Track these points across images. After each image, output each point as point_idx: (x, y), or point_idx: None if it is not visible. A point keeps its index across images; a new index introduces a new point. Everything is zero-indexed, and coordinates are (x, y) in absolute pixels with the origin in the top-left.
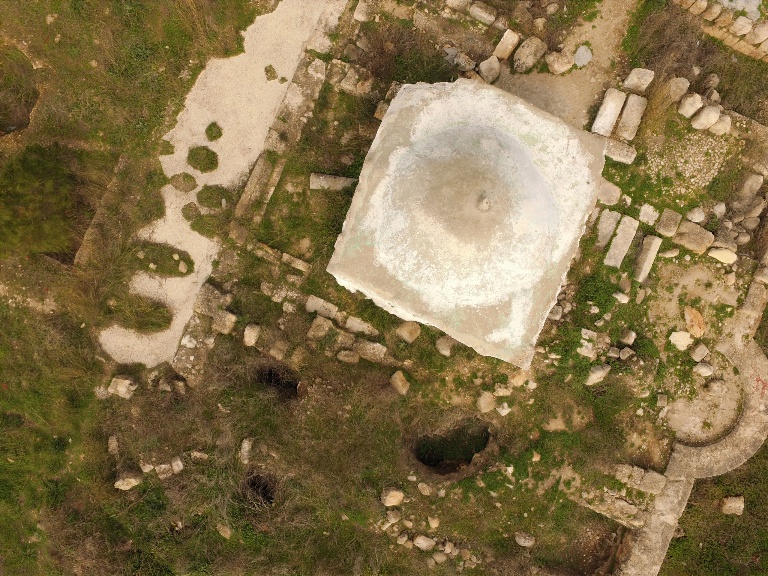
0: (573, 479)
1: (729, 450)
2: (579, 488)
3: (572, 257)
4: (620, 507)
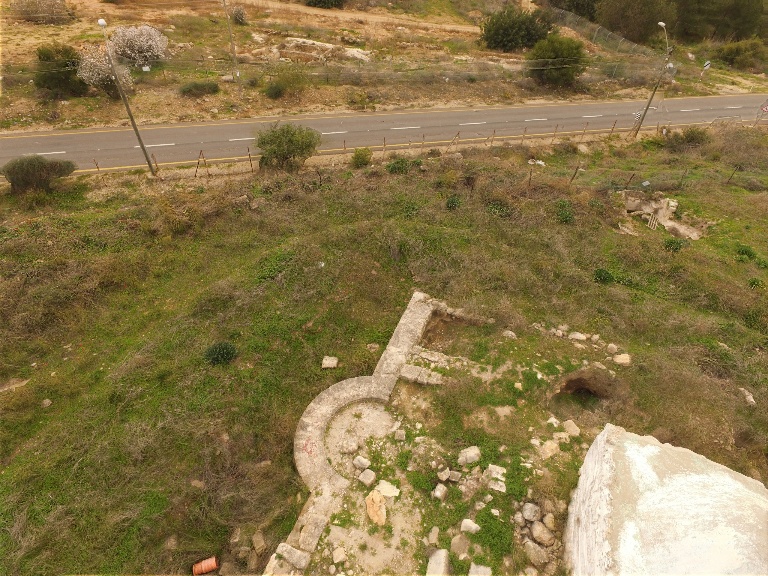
0: (479, 373)
1: (343, 396)
2: (471, 368)
3: (609, 529)
4: (434, 357)
